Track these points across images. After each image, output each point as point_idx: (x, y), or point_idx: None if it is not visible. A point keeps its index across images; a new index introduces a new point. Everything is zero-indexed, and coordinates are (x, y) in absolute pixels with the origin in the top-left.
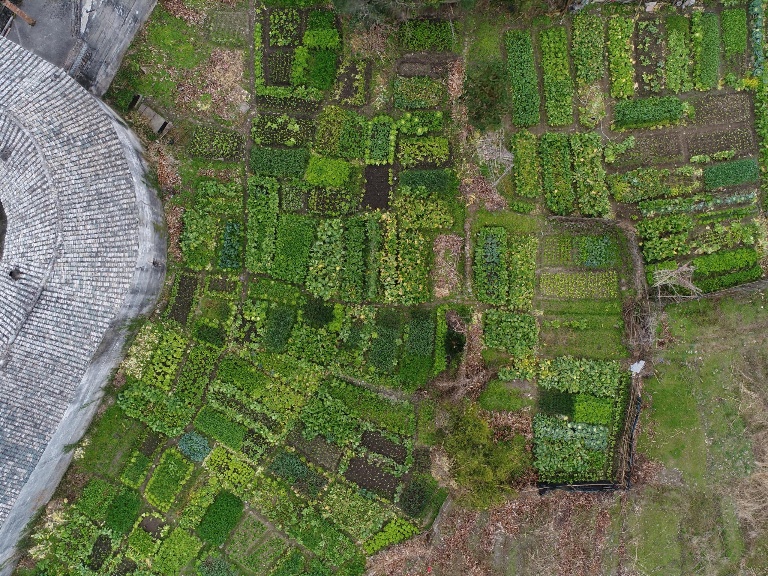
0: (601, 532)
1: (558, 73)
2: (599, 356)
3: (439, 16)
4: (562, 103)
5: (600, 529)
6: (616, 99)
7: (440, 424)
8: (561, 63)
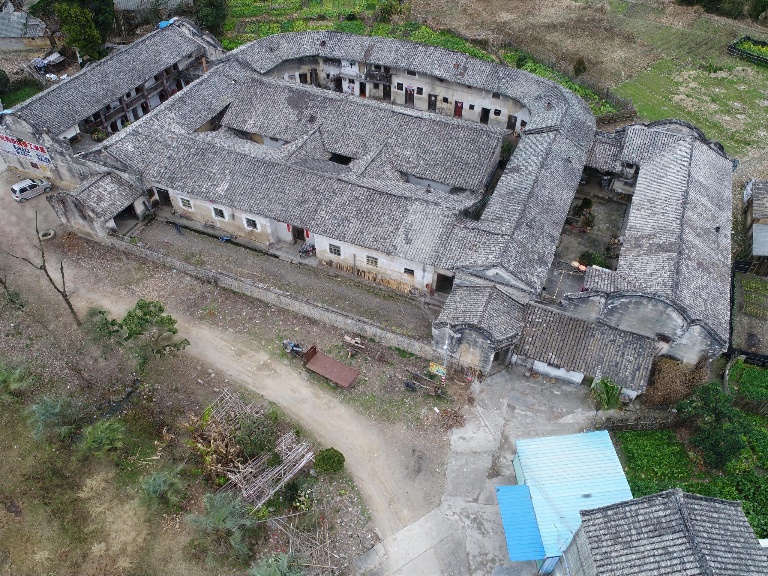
0: (417, 2)
1: (249, 8)
2: (354, 2)
3: (222, 25)
4: (260, 6)
5: (416, 2)
6: (260, 1)
7: (380, 12)
8: (245, 7)
